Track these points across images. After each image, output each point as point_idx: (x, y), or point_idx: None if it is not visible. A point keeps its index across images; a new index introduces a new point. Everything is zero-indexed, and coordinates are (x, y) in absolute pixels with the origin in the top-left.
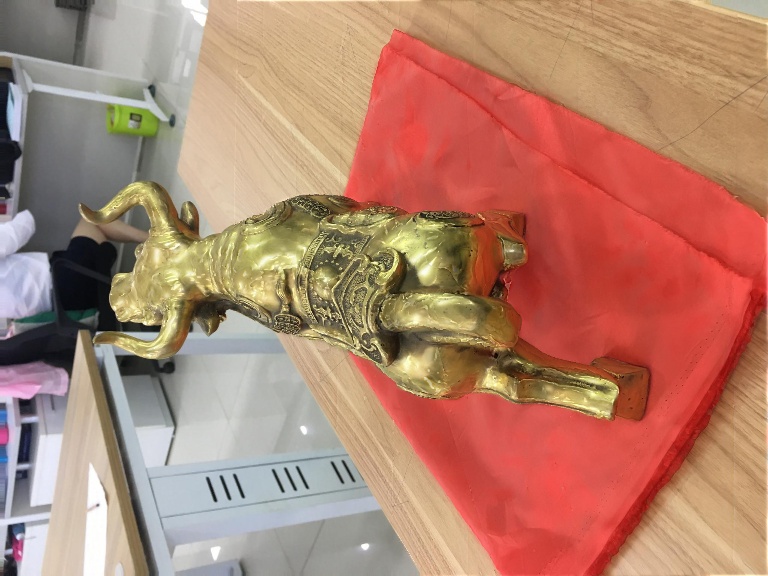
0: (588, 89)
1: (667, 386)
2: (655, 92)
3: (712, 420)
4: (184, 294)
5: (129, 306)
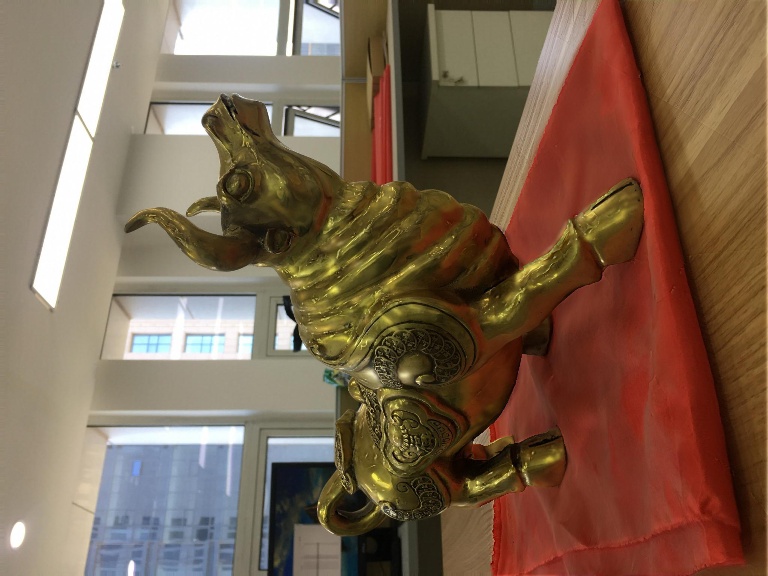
0: None
1: None
2: None
3: None
4: None
5: None
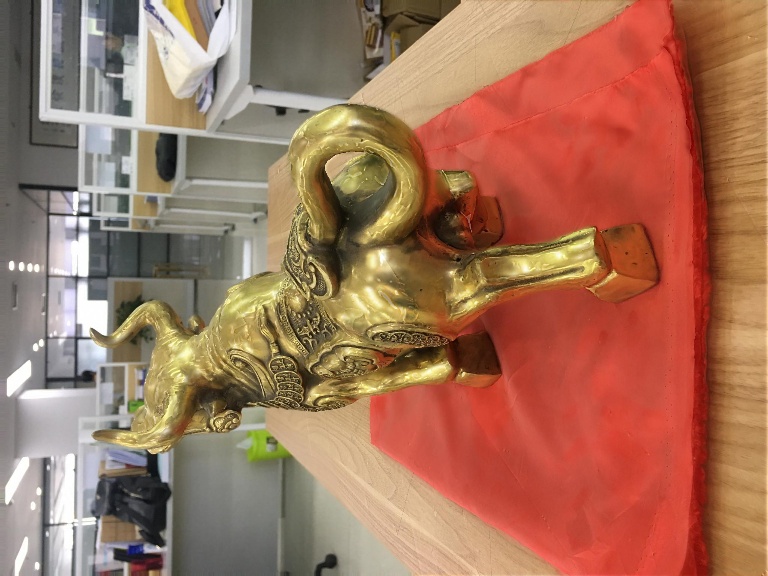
0: (501, 60)
1: (663, 222)
2: (543, 12)
3: (717, 214)
4: (186, 381)
5: (147, 429)
